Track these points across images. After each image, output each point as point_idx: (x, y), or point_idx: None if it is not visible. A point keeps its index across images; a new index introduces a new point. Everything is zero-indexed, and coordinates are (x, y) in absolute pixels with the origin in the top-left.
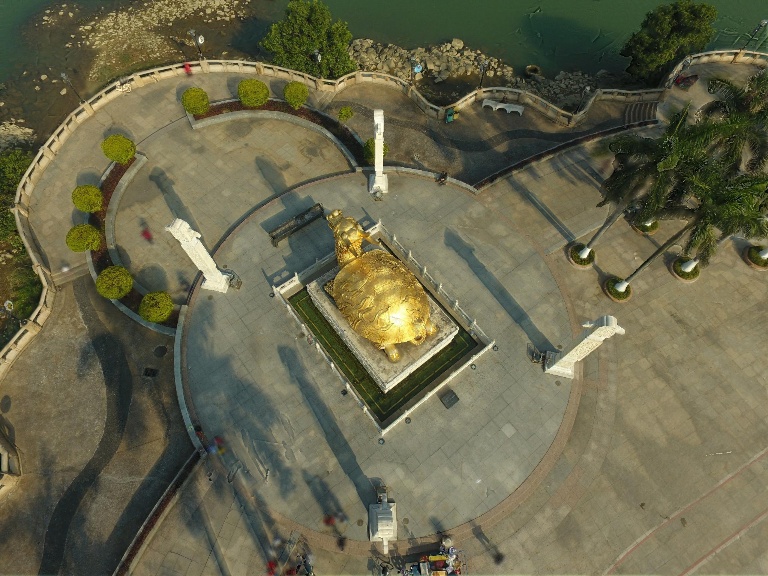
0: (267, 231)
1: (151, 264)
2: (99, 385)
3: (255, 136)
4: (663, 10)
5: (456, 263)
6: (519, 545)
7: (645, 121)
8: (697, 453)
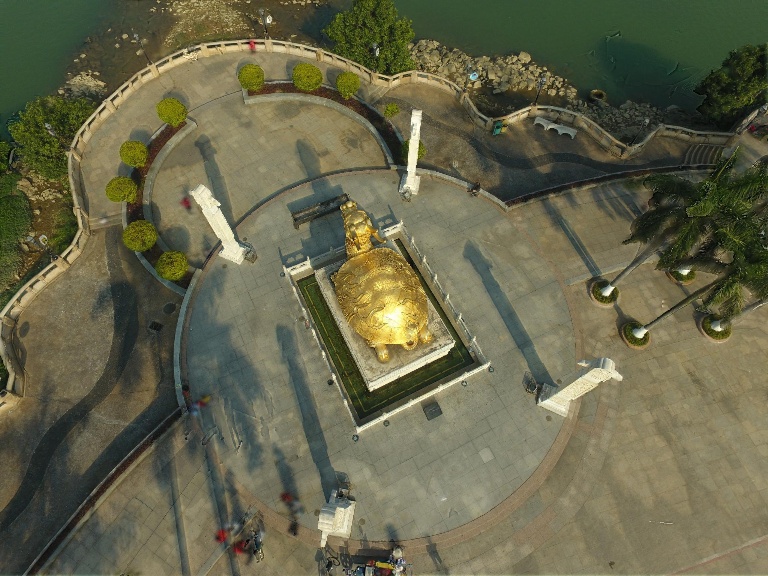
0: (292, 212)
1: (179, 225)
2: (108, 329)
3: (301, 119)
4: (748, 50)
5: (470, 277)
6: (471, 573)
7: (705, 165)
8: (685, 523)
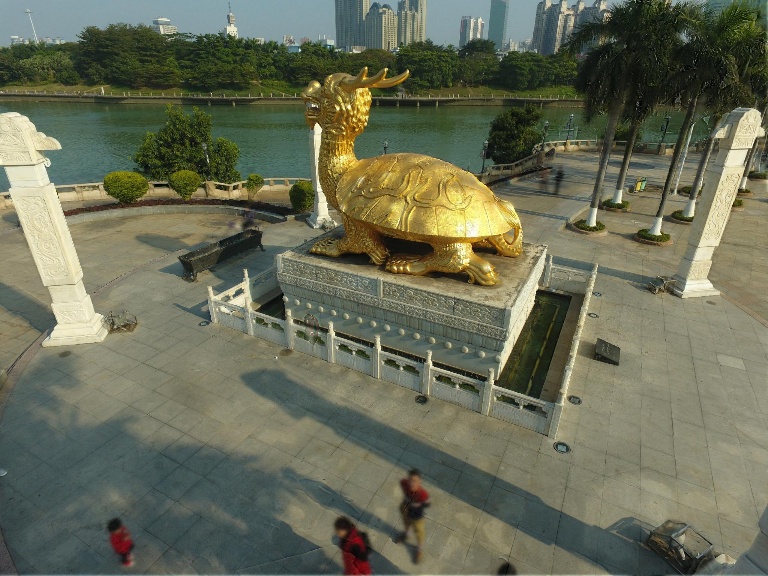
0: (173, 273)
1: None
2: None
3: (131, 225)
4: (501, 115)
5: None
6: None
7: (542, 168)
8: None
